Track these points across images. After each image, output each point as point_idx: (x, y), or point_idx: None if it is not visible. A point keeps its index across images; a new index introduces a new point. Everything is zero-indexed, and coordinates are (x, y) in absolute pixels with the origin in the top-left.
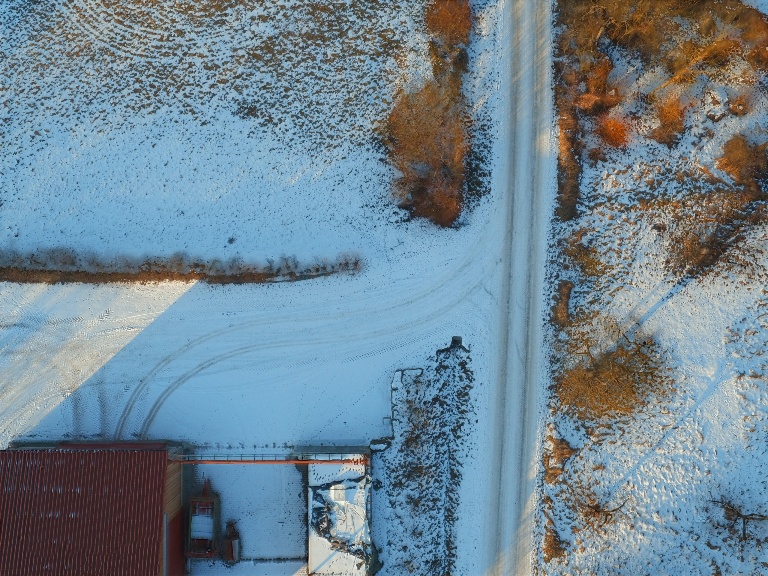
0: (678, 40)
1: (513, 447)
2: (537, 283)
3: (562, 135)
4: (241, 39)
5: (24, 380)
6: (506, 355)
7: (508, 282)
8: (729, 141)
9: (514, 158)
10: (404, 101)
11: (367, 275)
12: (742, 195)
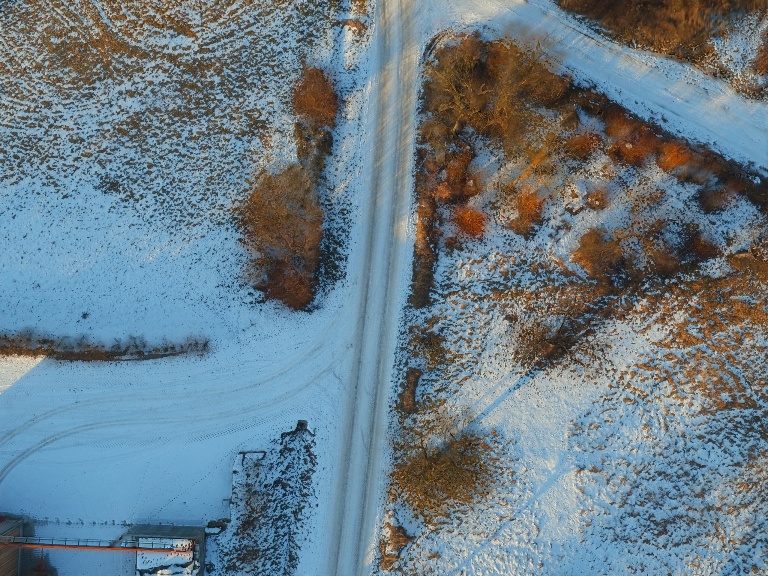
0: (541, 132)
1: (351, 532)
2: (386, 370)
3: (419, 223)
4: (107, 113)
5: None
6: (351, 440)
7: (357, 367)
8: (585, 235)
9: (371, 243)
10: (266, 182)
11: (216, 356)
12: (595, 289)
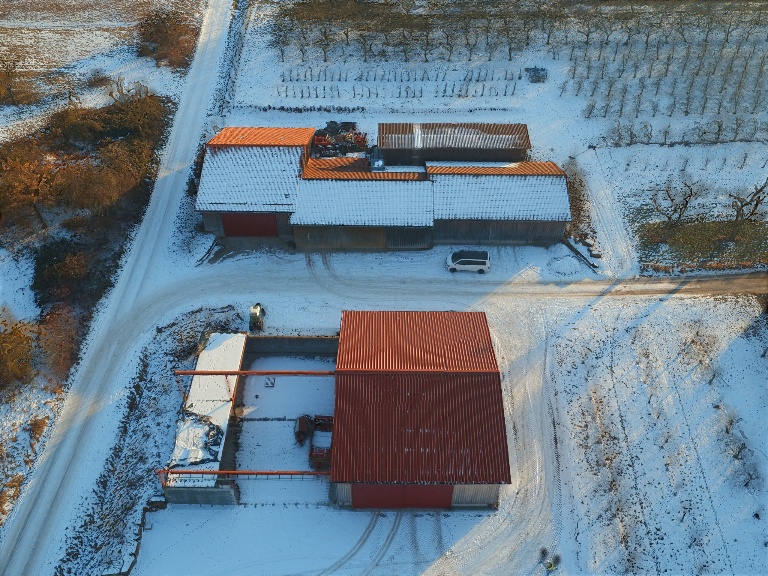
0: None
1: (42, 505)
2: None
3: None
4: None
5: (492, 567)
6: None
7: None
8: None
9: None
10: None
11: None
12: None
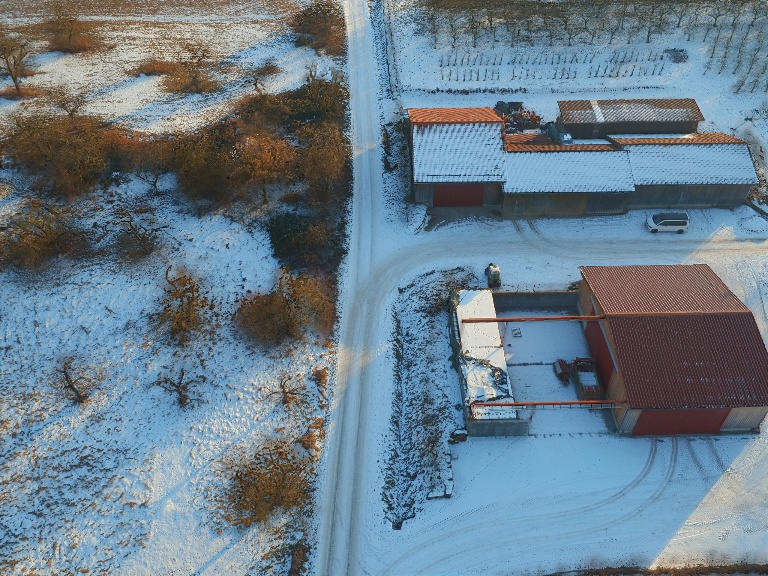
0: None
1: (348, 443)
2: None
3: None
4: None
5: None
6: (352, 516)
7: None
8: None
9: None
10: None
11: None
12: None
